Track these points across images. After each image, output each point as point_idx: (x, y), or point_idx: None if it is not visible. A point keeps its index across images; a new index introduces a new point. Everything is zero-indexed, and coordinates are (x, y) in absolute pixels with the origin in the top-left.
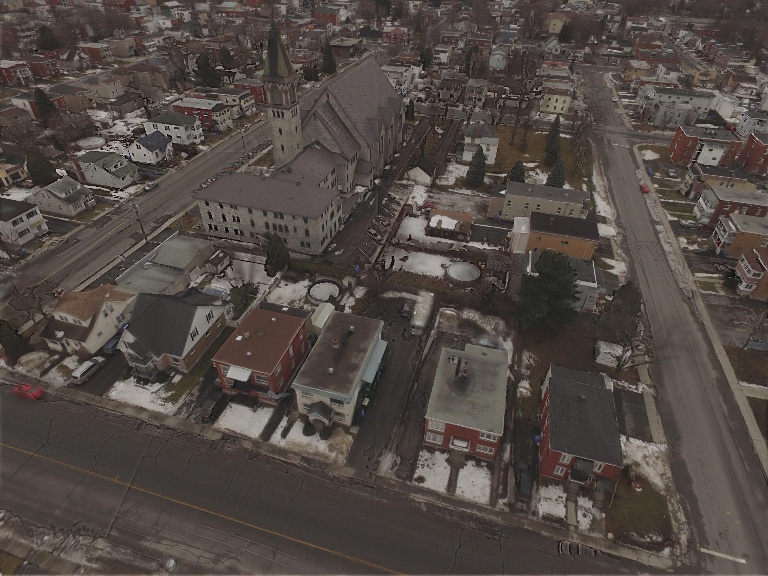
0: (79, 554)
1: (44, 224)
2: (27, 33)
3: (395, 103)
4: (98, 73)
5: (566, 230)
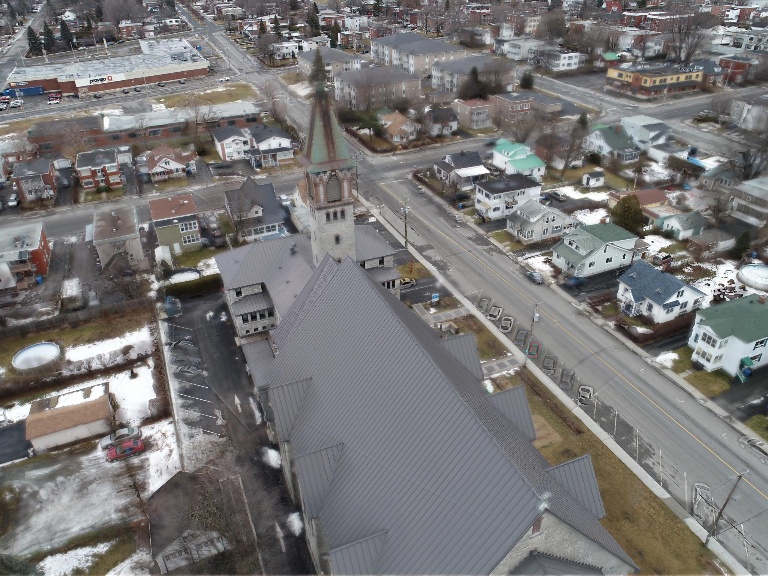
0: (196, 187)
1: (490, 211)
2: None
3: None
4: None
5: None
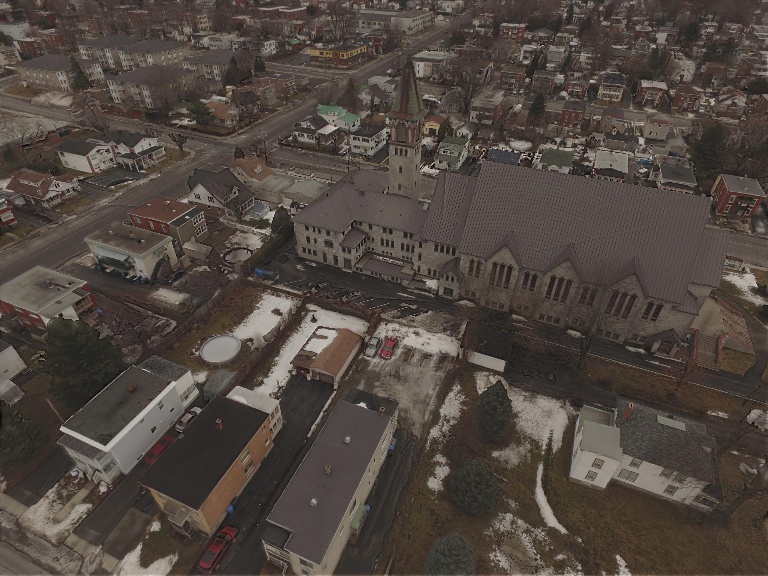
0: (106, 200)
1: (370, 151)
2: (760, 72)
3: (627, 269)
4: (724, 122)
5: (198, 447)
